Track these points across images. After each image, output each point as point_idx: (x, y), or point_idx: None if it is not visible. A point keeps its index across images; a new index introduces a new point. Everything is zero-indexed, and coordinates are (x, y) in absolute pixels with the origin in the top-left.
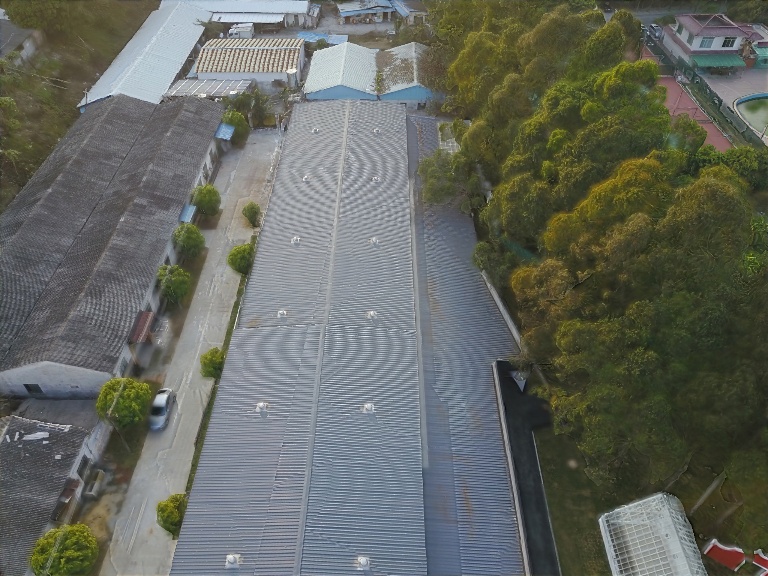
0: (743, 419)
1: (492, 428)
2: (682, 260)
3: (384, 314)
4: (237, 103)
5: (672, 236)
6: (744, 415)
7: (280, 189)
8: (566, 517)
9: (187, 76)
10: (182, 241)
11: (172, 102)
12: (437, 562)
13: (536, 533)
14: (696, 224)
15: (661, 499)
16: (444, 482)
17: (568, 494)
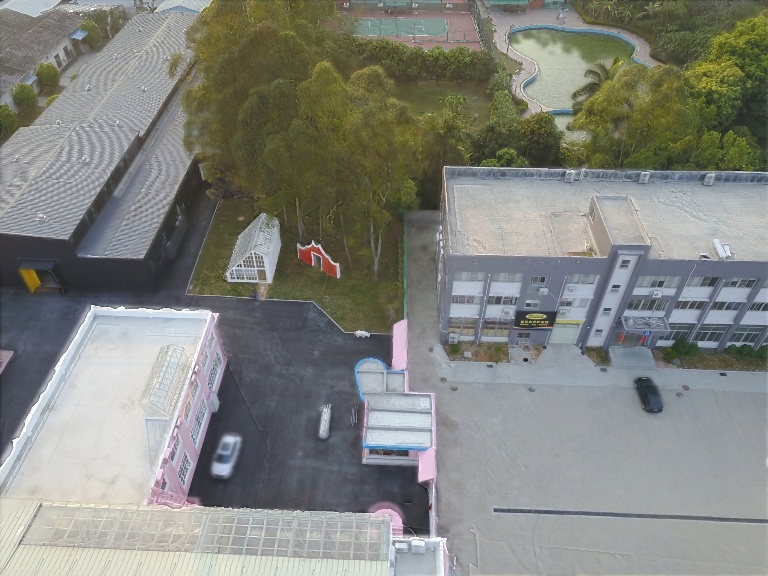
0: (229, 115)
1: (175, 184)
2: (217, 36)
3: (127, 124)
4: (95, 16)
5: (212, 22)
6: (227, 112)
7: (95, 62)
8: (219, 240)
9: (69, 2)
10: (17, 94)
11: (44, 14)
12: (100, 233)
13: (193, 245)
14: (214, 10)
15: (262, 216)
16: (126, 204)
17: (228, 231)
